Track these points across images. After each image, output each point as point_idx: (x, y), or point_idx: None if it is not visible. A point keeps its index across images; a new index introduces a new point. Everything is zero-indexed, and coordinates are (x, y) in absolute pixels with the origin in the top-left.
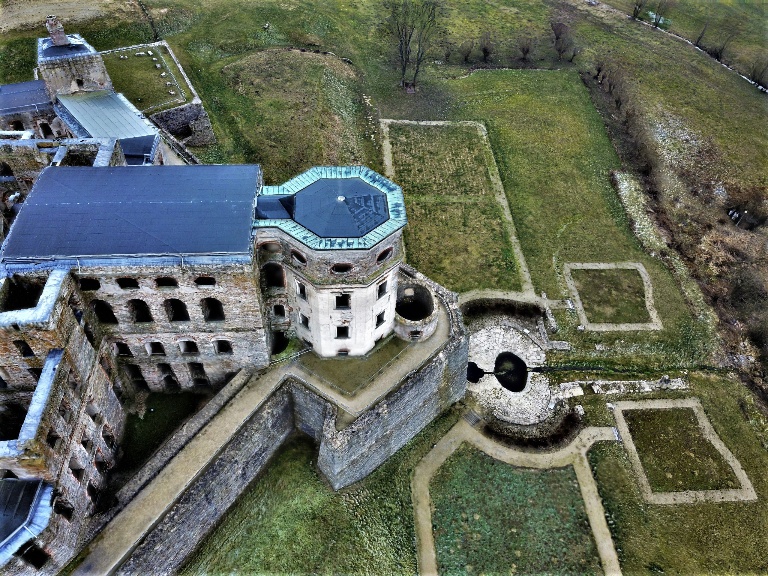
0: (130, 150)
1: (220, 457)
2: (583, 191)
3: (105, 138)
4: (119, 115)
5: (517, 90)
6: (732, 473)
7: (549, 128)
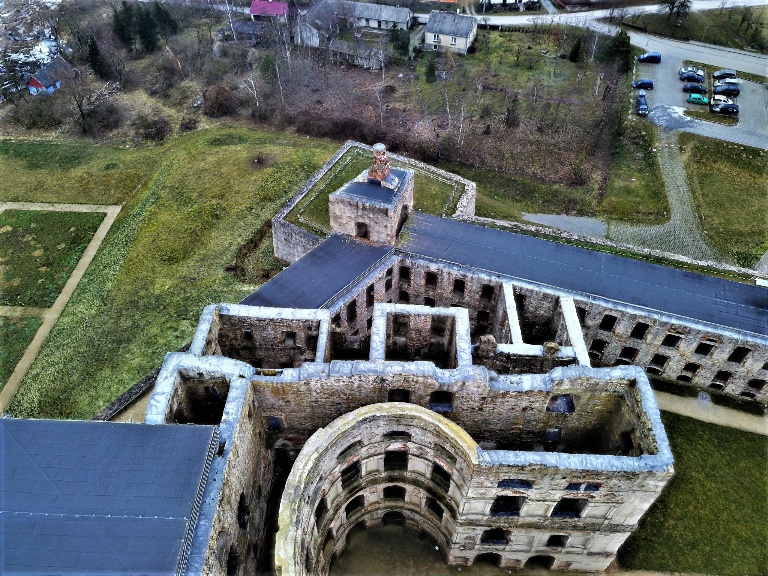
0: None
1: (111, 411)
2: None
3: None
4: None
5: None
6: None
7: None
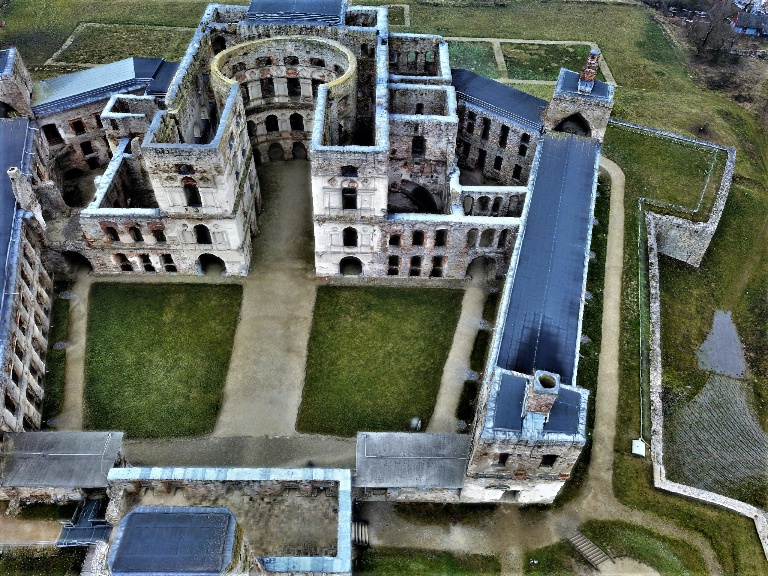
0: (153, 65)
1: None
2: (190, 2)
3: (209, 7)
4: (90, 74)
5: (46, 4)
6: (397, 7)
7: (110, 1)
